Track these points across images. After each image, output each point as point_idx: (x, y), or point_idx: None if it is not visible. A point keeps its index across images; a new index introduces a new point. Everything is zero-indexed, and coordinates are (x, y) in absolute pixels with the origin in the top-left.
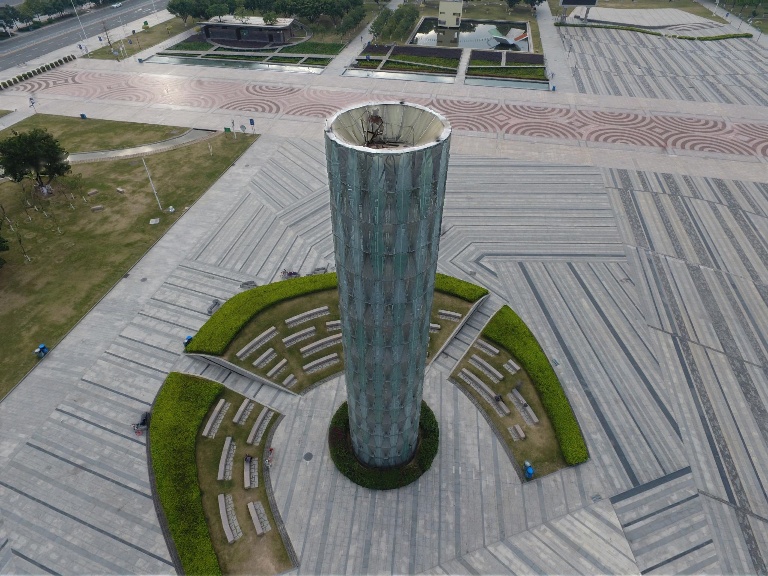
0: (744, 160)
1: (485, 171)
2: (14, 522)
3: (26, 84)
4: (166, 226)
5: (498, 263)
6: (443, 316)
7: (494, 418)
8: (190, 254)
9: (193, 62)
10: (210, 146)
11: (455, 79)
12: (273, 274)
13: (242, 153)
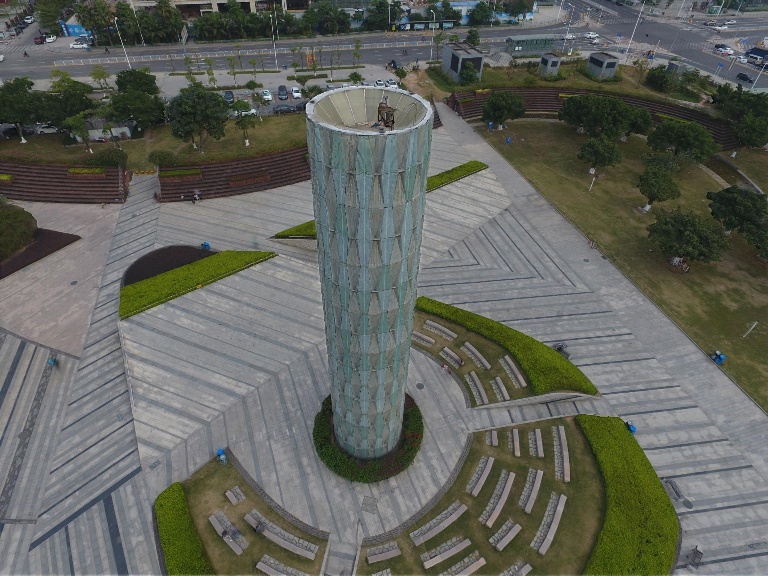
0: None
1: None
2: (553, 284)
3: None
4: None
5: None
6: None
7: (262, 505)
8: None
9: None
10: None
11: None
12: None
13: None
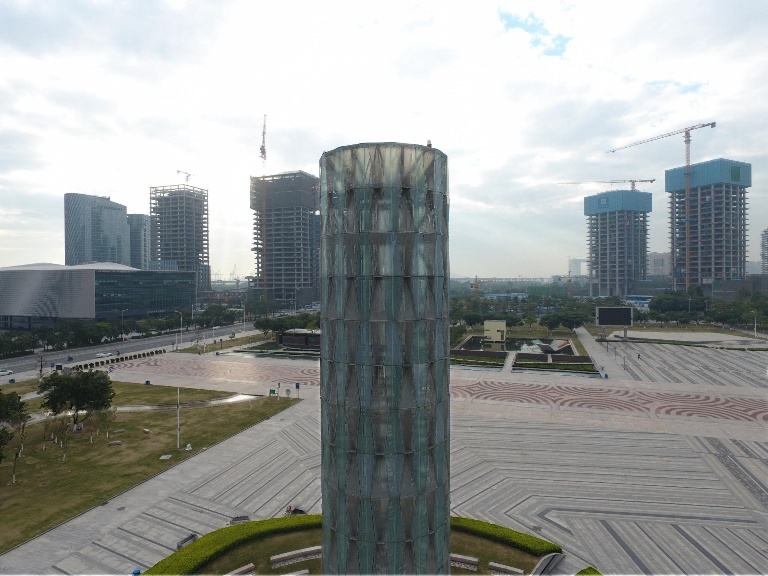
0: None
1: (541, 433)
2: None
3: (115, 365)
4: (175, 462)
5: (571, 519)
6: (496, 572)
7: None
8: (187, 487)
9: (261, 356)
10: (251, 404)
11: (502, 369)
12: (275, 512)
13: (280, 411)
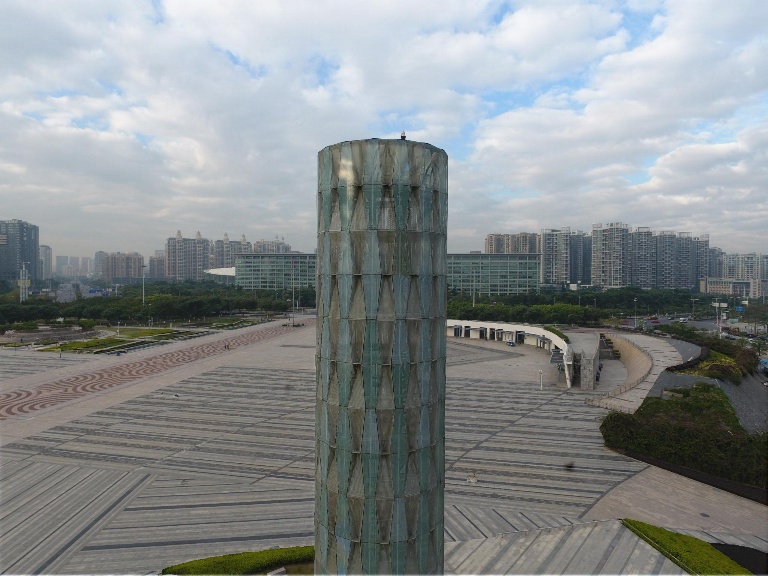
0: (87, 399)
1: None
2: None
3: None
4: None
5: (62, 570)
6: None
7: None
8: None
9: None
10: None
11: None
12: None
13: None
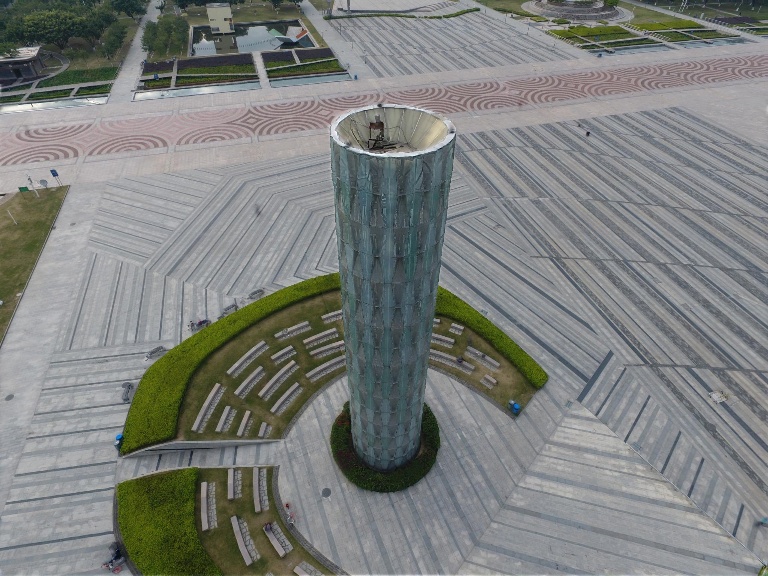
0: (524, 109)
1: None
2: None
3: None
4: (2, 324)
5: None
6: None
7: (465, 378)
8: (58, 345)
9: None
10: (8, 214)
11: (260, 84)
12: (179, 331)
13: (57, 212)
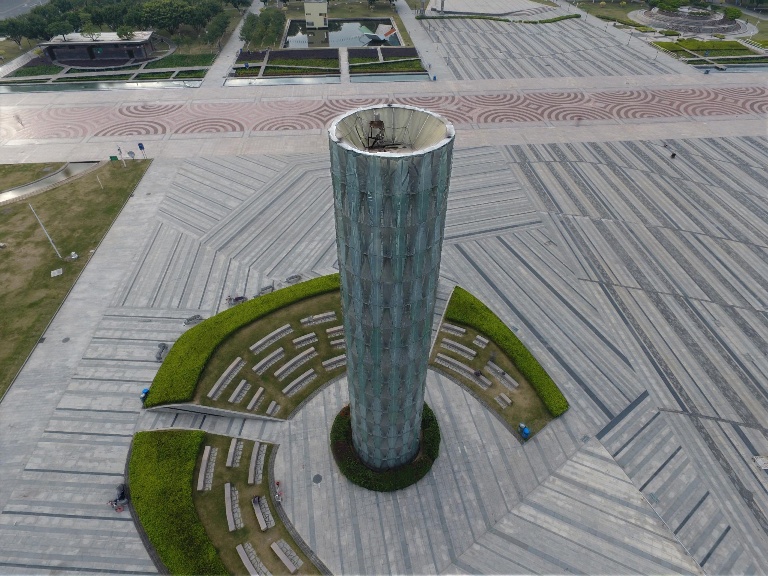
0: (607, 124)
1: None
2: None
3: None
4: (73, 275)
5: None
6: None
7: (479, 392)
8: (114, 301)
9: (44, 88)
10: None
11: (340, 78)
12: (217, 303)
13: (138, 181)
